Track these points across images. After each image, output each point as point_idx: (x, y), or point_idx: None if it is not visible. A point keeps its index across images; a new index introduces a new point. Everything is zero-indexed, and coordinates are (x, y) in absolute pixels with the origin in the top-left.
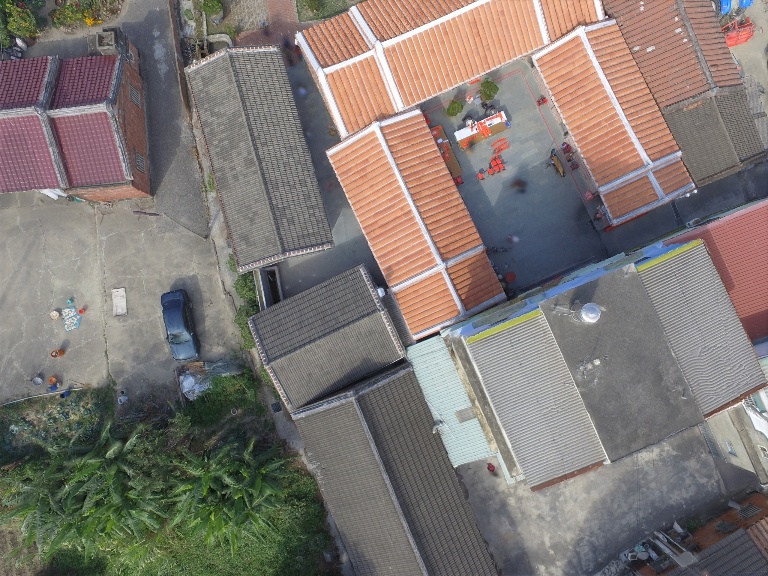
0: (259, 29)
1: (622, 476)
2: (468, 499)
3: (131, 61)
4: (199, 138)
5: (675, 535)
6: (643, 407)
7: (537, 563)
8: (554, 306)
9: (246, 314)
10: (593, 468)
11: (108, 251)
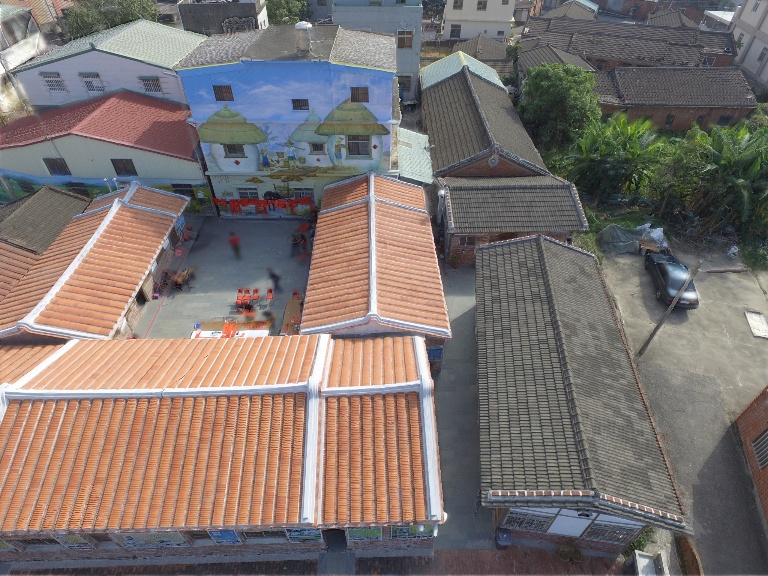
0: None
1: None
2: None
3: None
4: None
5: None
6: None
7: None
8: None
9: None
10: None
11: None
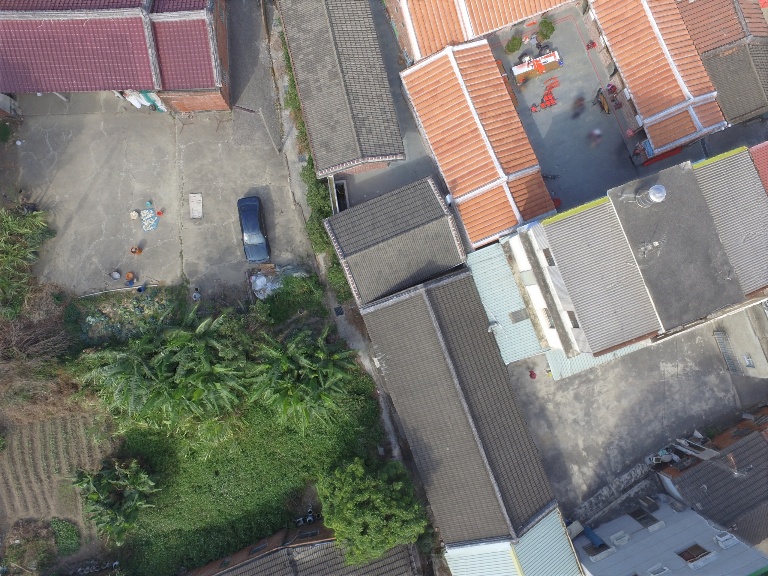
0: None
1: (650, 387)
2: None
3: None
4: (276, 60)
5: (696, 440)
6: (694, 285)
7: (571, 463)
8: (621, 194)
9: (317, 220)
10: (649, 337)
11: (187, 159)
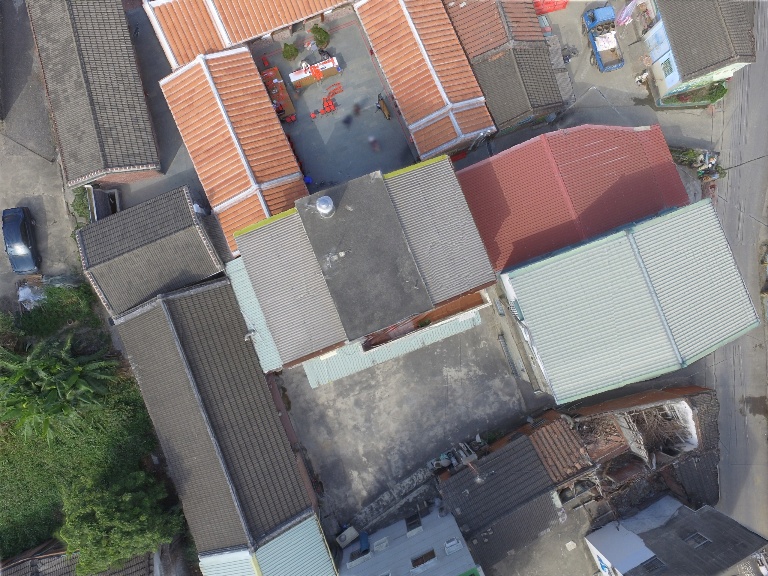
0: None
1: (432, 392)
2: (290, 410)
3: None
4: None
5: (474, 444)
6: (380, 294)
7: (351, 469)
8: (307, 205)
9: None
10: (336, 347)
11: None
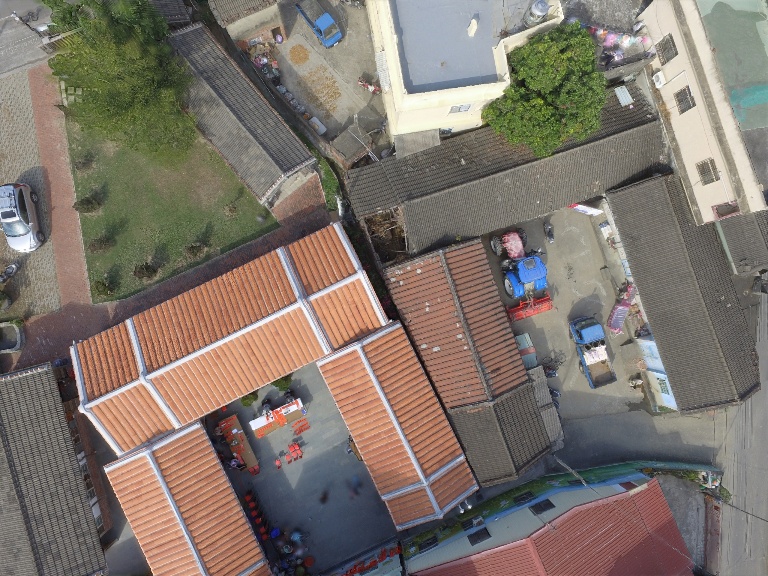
0: (50, 312)
1: None
2: None
3: None
4: None
5: None
6: None
7: None
8: None
9: None
10: None
11: None
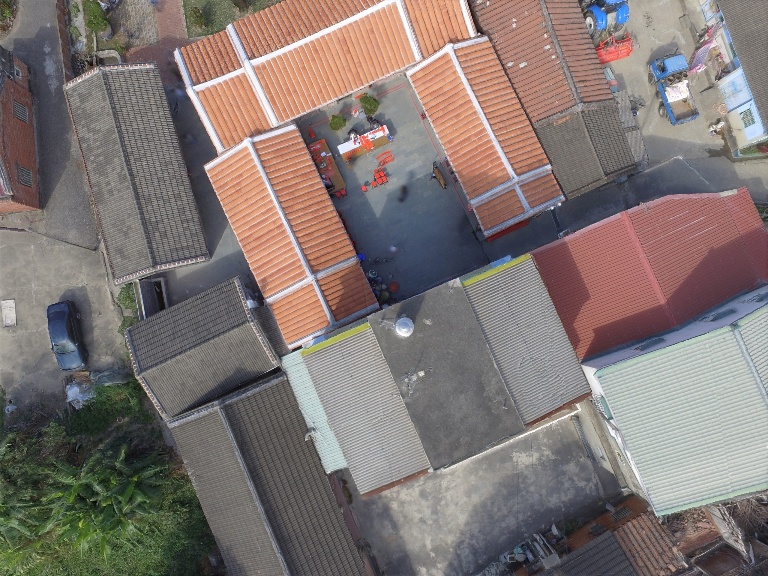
0: (149, 45)
1: (502, 480)
2: (352, 504)
3: (17, 77)
4: None
5: (551, 537)
6: (465, 417)
7: (418, 565)
8: (381, 320)
9: (129, 325)
10: None
11: None
